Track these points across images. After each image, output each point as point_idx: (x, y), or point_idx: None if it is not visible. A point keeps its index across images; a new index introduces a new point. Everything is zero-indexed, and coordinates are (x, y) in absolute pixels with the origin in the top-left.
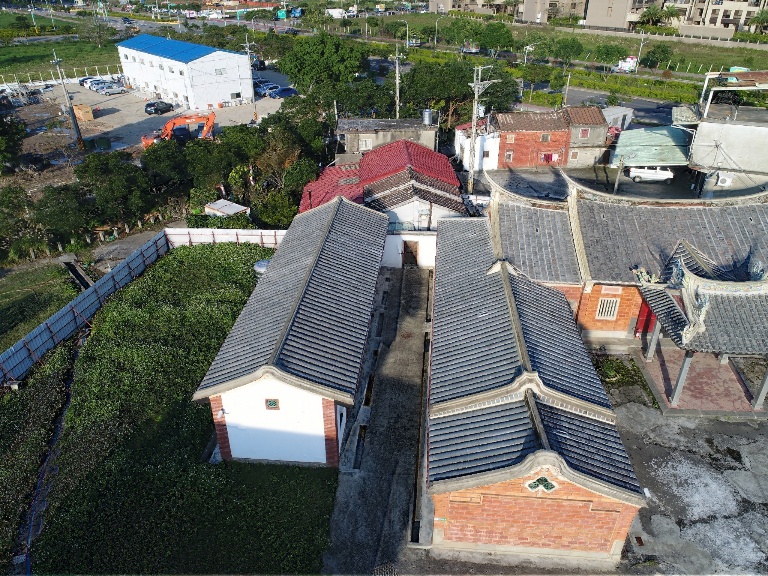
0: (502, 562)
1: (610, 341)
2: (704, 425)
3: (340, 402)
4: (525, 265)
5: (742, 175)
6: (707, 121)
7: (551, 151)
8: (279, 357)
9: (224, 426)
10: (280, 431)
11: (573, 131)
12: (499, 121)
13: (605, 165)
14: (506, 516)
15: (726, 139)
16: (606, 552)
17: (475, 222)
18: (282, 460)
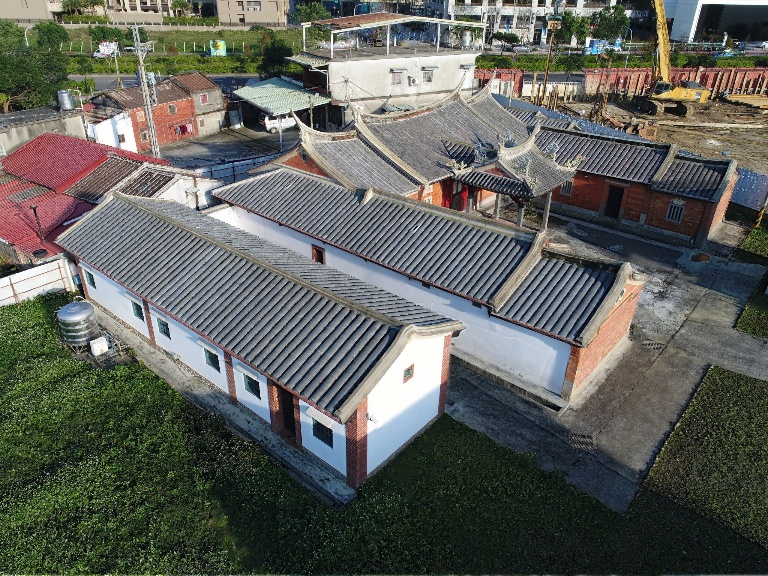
0: (601, 380)
1: None
2: None
3: (458, 331)
4: None
5: (367, 102)
6: (335, 61)
7: (184, 122)
8: None
9: (365, 437)
10: (409, 404)
11: (194, 98)
12: (118, 100)
13: (228, 127)
14: None
15: (350, 74)
16: None
17: (272, 177)
18: (407, 441)
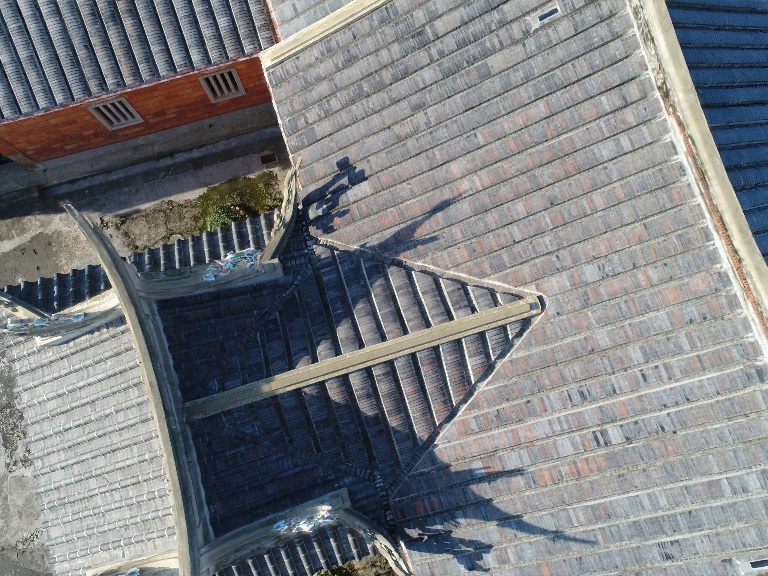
0: None
1: None
2: None
3: None
4: None
5: None
6: None
7: None
8: None
9: None
10: None
11: None
12: None
13: None
14: None
15: None
16: None
17: None
18: None
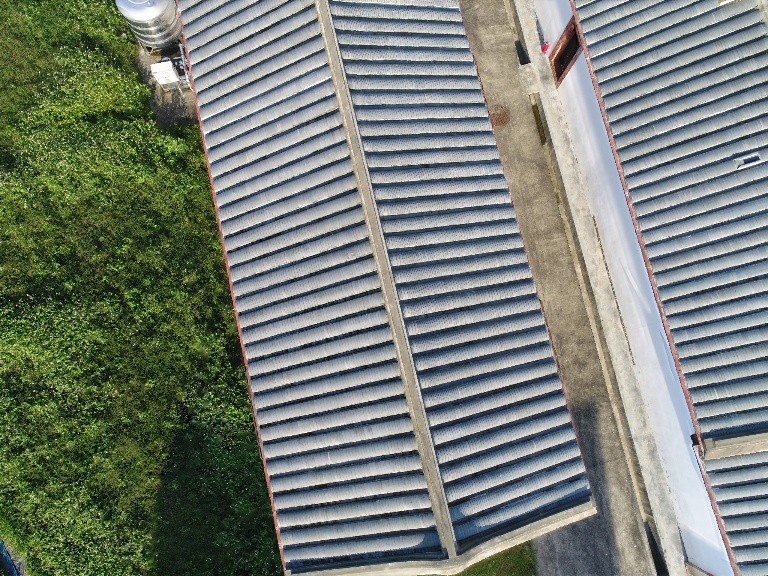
0: None
1: None
2: None
3: None
4: None
5: None
6: None
7: None
8: (447, 503)
9: None
10: None
11: None
12: None
13: None
14: None
15: None
16: None
17: None
18: None
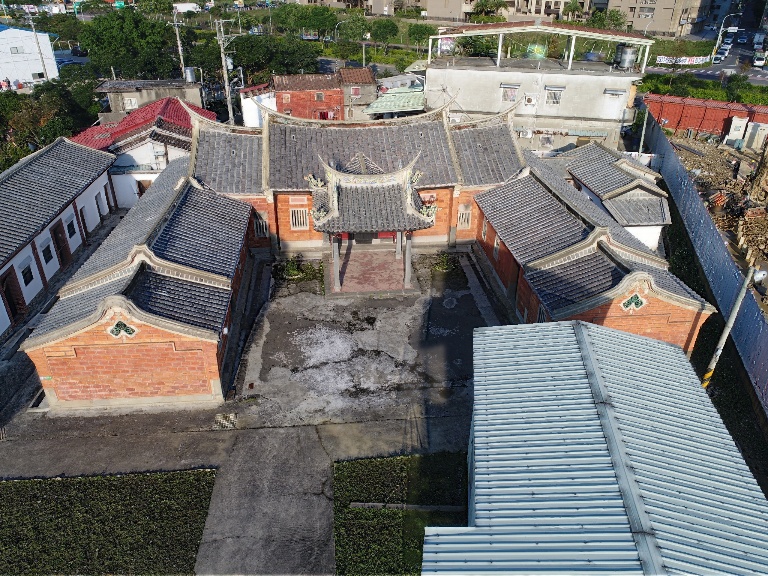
0: (114, 413)
1: (307, 249)
2: (357, 302)
3: None
4: (214, 181)
5: None
6: (431, 67)
7: (326, 109)
8: None
9: None
10: None
11: (345, 90)
12: (275, 82)
13: None
14: (105, 367)
15: (450, 83)
16: (209, 393)
17: None
18: None
